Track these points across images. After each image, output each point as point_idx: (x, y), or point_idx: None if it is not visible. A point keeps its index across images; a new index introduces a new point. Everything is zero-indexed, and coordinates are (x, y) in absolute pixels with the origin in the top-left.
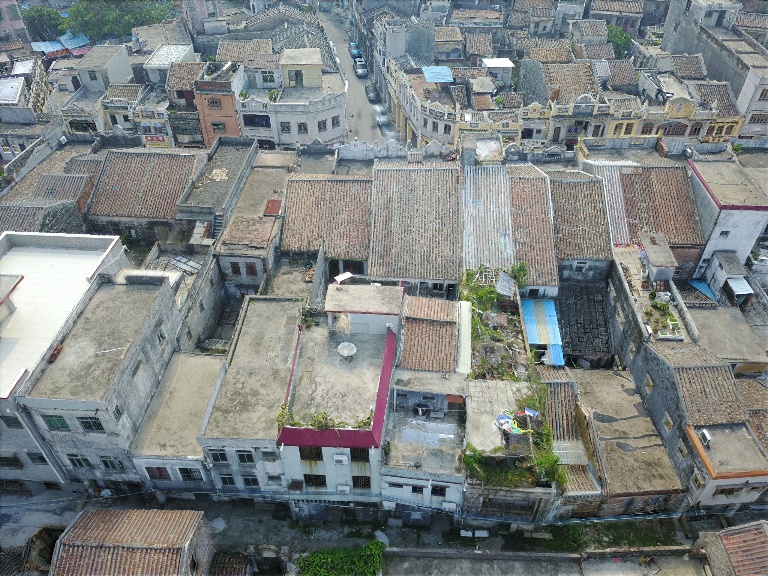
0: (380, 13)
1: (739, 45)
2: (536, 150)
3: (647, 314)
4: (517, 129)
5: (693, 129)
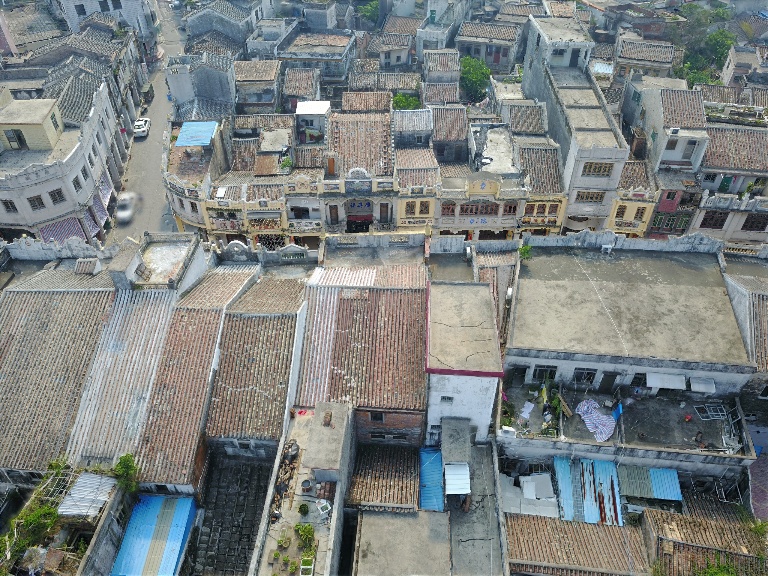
0: (199, 41)
1: (584, 95)
2: (311, 232)
3: (280, 546)
4: (279, 208)
5: (507, 208)
